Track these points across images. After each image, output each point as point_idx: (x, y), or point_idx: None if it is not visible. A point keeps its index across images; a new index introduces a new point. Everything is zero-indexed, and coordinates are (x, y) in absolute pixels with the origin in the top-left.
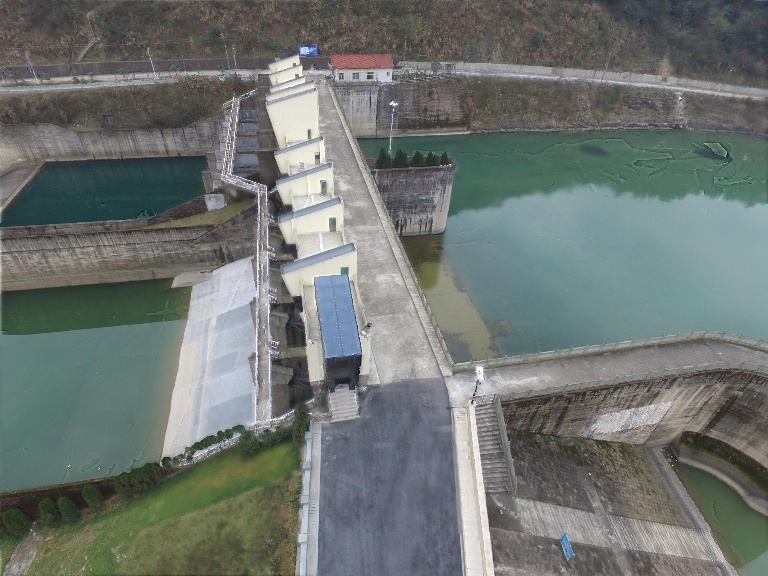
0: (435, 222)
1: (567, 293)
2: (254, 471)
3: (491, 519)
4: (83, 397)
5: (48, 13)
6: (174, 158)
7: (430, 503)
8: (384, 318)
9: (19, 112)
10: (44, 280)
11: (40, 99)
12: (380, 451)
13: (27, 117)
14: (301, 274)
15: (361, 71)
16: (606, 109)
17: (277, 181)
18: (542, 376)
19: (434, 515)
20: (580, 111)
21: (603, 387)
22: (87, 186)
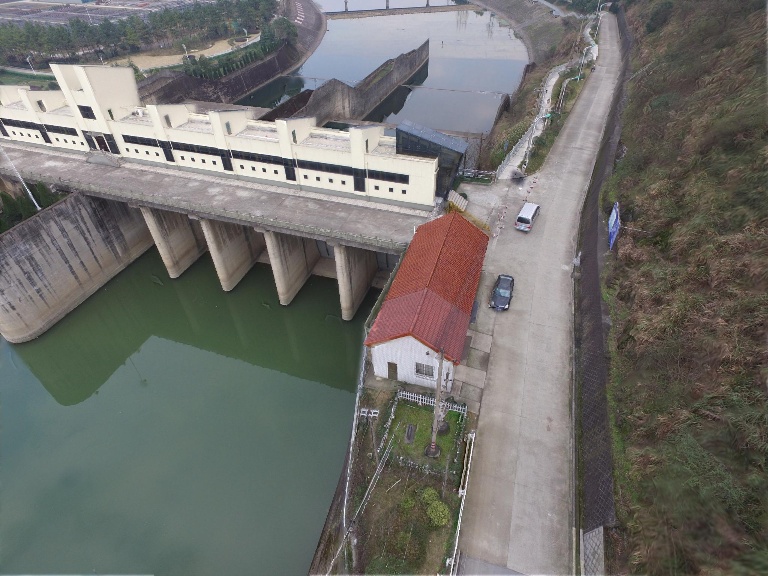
0: None
1: None
2: None
3: None
4: None
5: None
6: None
7: None
8: None
9: None
10: None
11: None
12: None
13: None
14: None
15: None
16: None
17: None
18: None
19: None
20: None
21: None
22: None
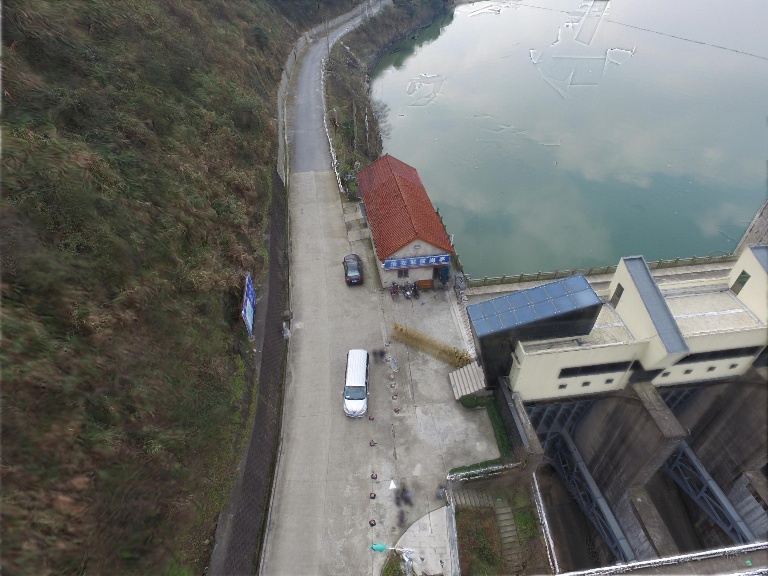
0: None
1: None
2: None
3: None
4: None
5: None
6: None
7: None
8: None
9: None
10: None
11: None
12: None
13: None
14: None
15: None
16: None
17: None
18: None
19: None
20: None
21: None
22: None
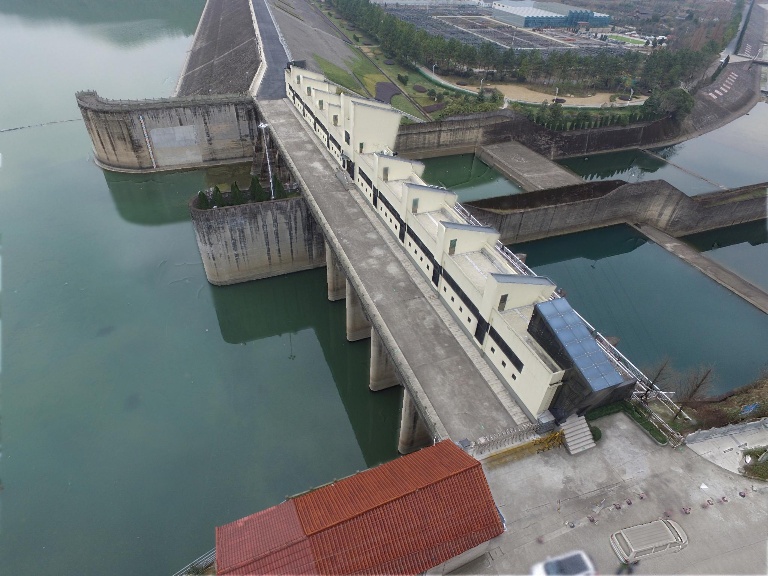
0: None
1: None
2: None
3: None
4: None
5: None
6: None
7: None
8: None
9: None
10: None
11: None
12: (283, 91)
13: None
14: None
15: None
16: None
17: None
18: None
19: None
20: None
21: None
22: None
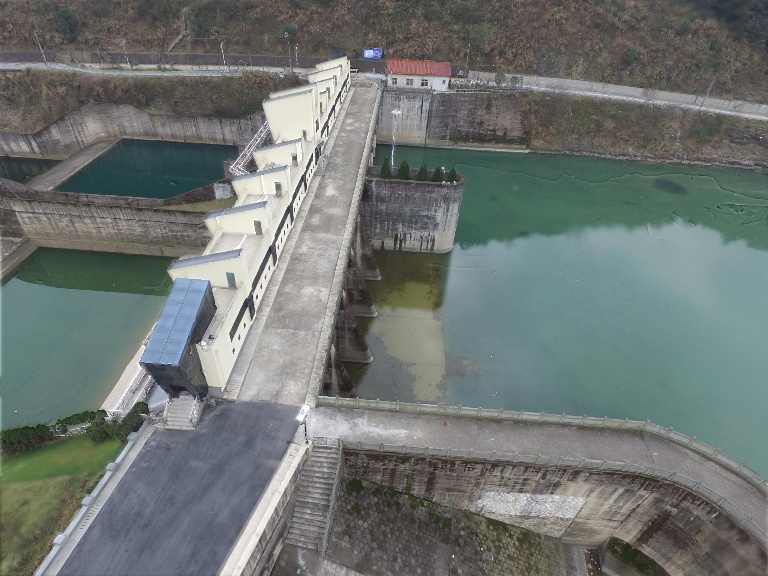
0: (438, 241)
1: (558, 342)
2: (87, 458)
3: (283, 575)
4: (58, 352)
5: (152, 7)
6: (230, 147)
7: (205, 540)
8: (284, 332)
9: (107, 92)
10: (72, 242)
11: (125, 82)
12: (192, 470)
13: (113, 97)
14: (186, 272)
15: (415, 77)
16: (700, 141)
17: (235, 177)
18: (413, 431)
19: (200, 554)
20: (666, 140)
21: (477, 460)
22: (155, 164)
